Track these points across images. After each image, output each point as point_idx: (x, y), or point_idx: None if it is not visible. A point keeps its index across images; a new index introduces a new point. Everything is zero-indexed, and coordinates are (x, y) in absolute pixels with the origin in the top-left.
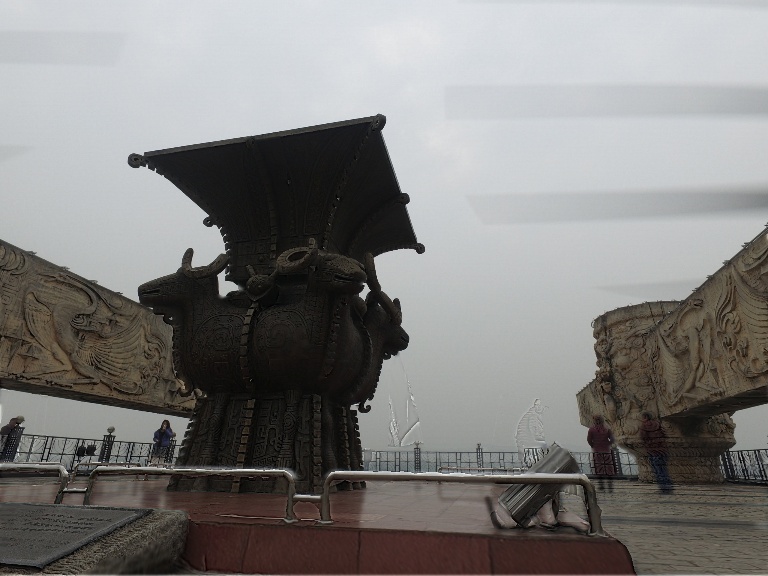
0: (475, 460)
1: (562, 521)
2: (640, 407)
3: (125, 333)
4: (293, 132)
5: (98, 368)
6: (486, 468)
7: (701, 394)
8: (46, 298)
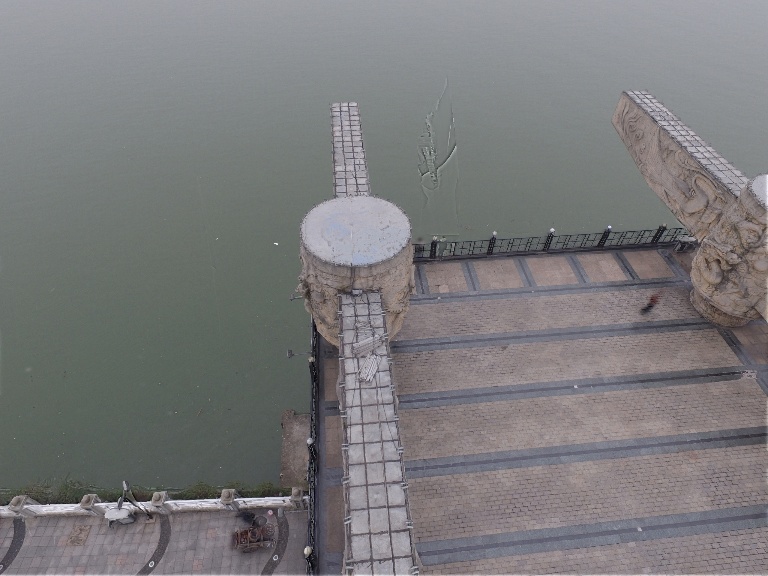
0: (544, 242)
1: None
2: (744, 297)
3: None
4: None
5: None
6: None
7: None
8: None
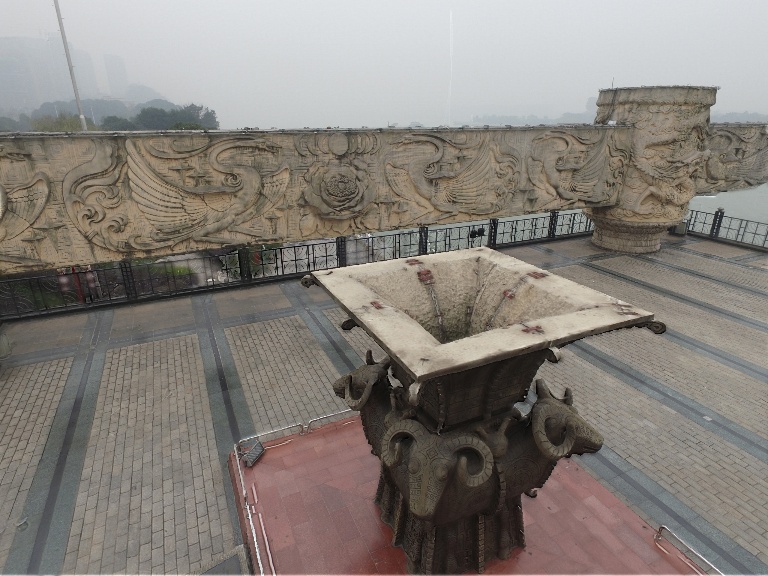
0: None
1: None
2: None
3: (474, 164)
4: (370, 332)
5: (455, 202)
6: (716, 570)
7: None
8: (401, 161)
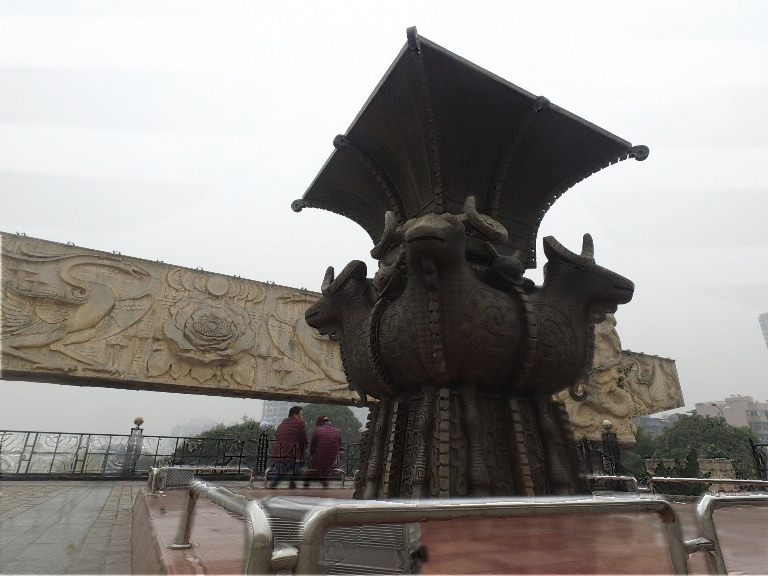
0: None
1: None
2: None
3: None
4: None
5: None
6: None
7: None
8: None
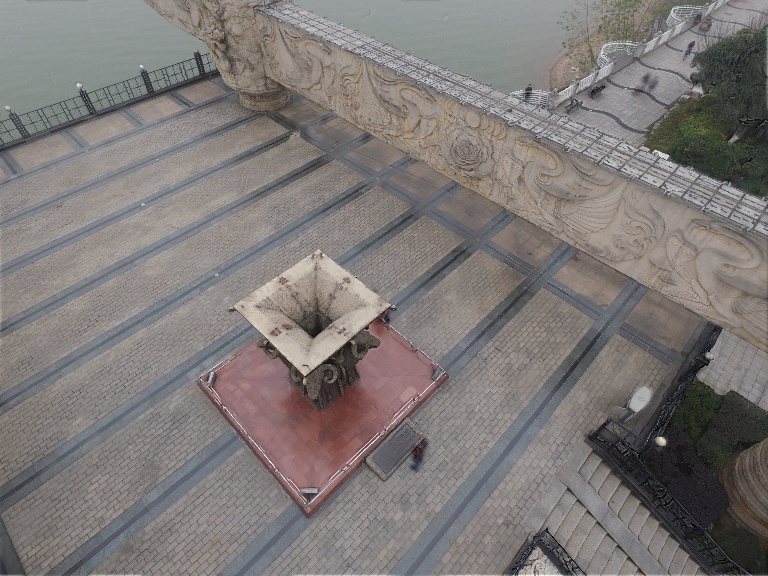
0: (83, 104)
1: (429, 364)
2: (252, 69)
3: None
4: None
5: None
6: None
7: (314, 97)
8: None
